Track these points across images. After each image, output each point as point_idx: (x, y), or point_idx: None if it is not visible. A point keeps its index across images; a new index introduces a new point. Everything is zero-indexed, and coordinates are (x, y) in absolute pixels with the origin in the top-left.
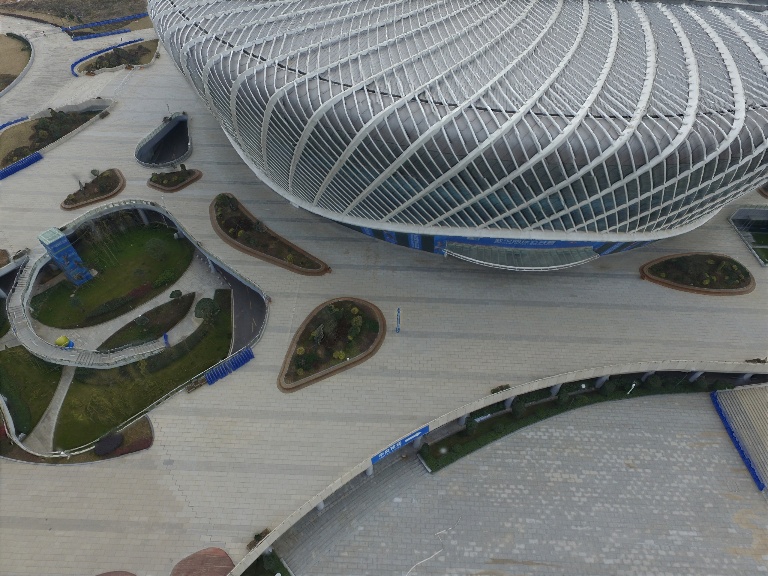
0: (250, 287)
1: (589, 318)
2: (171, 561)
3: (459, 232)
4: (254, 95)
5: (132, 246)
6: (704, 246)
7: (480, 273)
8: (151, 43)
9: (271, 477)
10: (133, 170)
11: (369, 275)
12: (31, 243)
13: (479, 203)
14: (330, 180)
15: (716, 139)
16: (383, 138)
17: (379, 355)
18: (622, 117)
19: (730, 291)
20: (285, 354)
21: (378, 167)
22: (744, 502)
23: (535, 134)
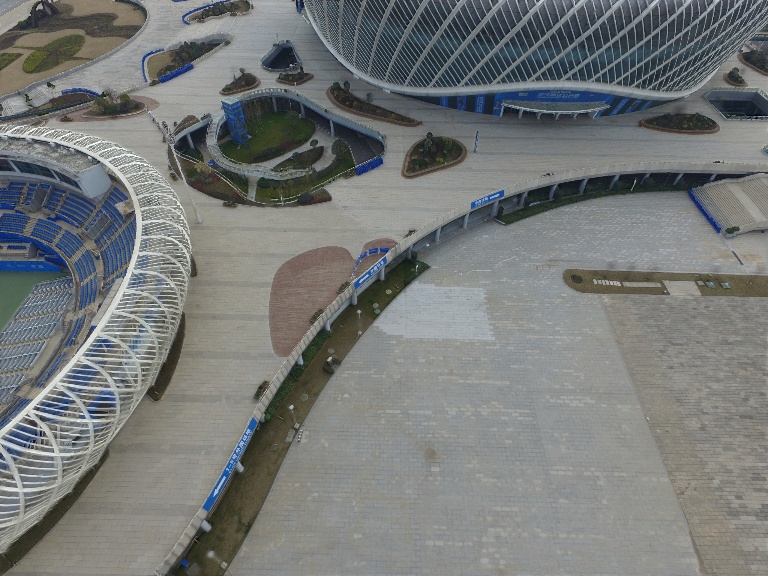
0: (367, 135)
1: (604, 145)
2: (362, 243)
3: (515, 86)
4: None
5: (271, 122)
6: (685, 110)
7: (526, 125)
8: (238, 2)
9: (410, 212)
10: (263, 74)
11: (449, 126)
12: None
13: (532, 55)
14: (427, 52)
15: None
16: (475, 5)
17: (465, 162)
18: None
19: (702, 131)
20: (403, 162)
21: (467, 31)
22: (707, 238)
23: None
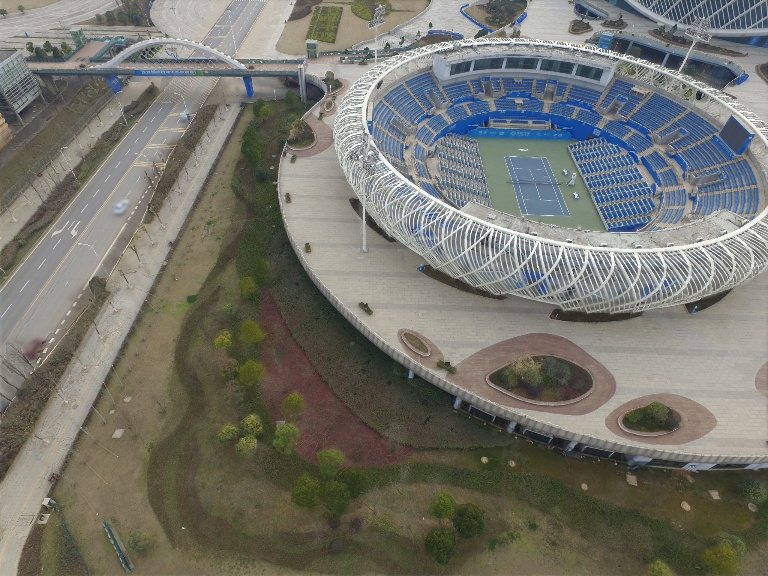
0: (708, 62)
1: None
2: None
3: None
4: None
5: None
6: None
7: None
8: None
9: None
10: (585, 21)
11: (767, 57)
12: None
13: None
14: None
15: None
16: None
17: None
18: None
19: None
20: (760, 78)
21: None
22: None
23: None
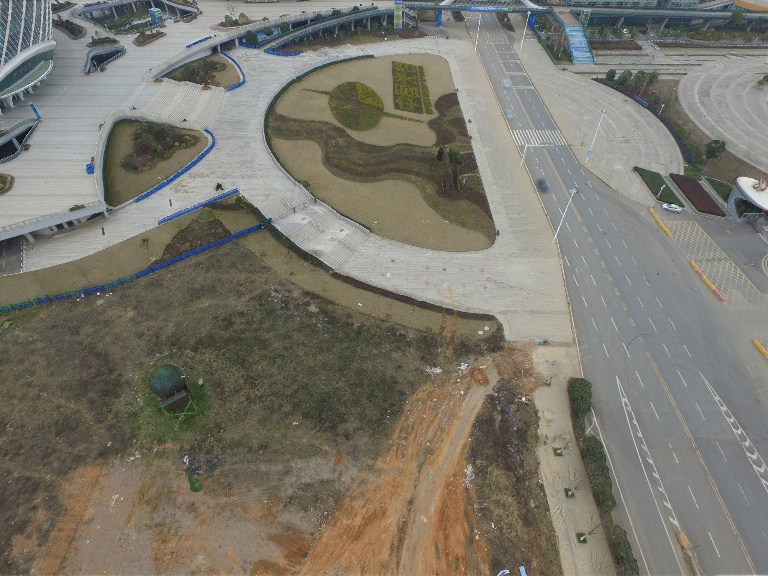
0: None
1: None
2: None
3: None
4: None
5: None
6: None
7: None
8: (123, 188)
9: None
10: (128, 46)
11: None
12: None
13: None
14: None
15: None
16: None
17: None
18: None
19: None
20: None
21: None
22: None
23: None
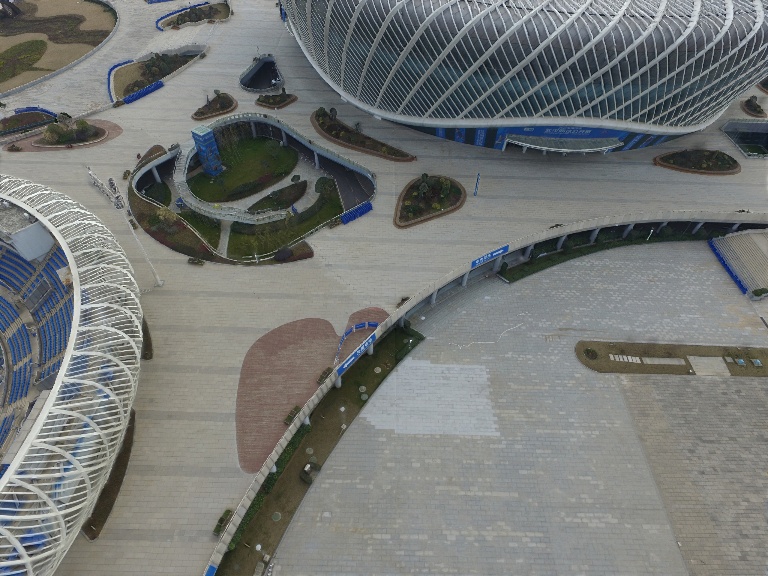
0: (355, 171)
1: (617, 188)
2: (347, 313)
3: (520, 121)
4: (377, 9)
5: (248, 150)
6: (702, 145)
7: (531, 161)
8: (217, 6)
9: (403, 273)
10: (240, 94)
11: (446, 162)
12: (178, 141)
13: (541, 90)
14: (423, 81)
15: (713, 32)
16: (478, 35)
17: (464, 208)
18: (648, 16)
19: (722, 172)
20: (395, 208)
21: (468, 62)
22: (733, 300)
23: (589, 27)
